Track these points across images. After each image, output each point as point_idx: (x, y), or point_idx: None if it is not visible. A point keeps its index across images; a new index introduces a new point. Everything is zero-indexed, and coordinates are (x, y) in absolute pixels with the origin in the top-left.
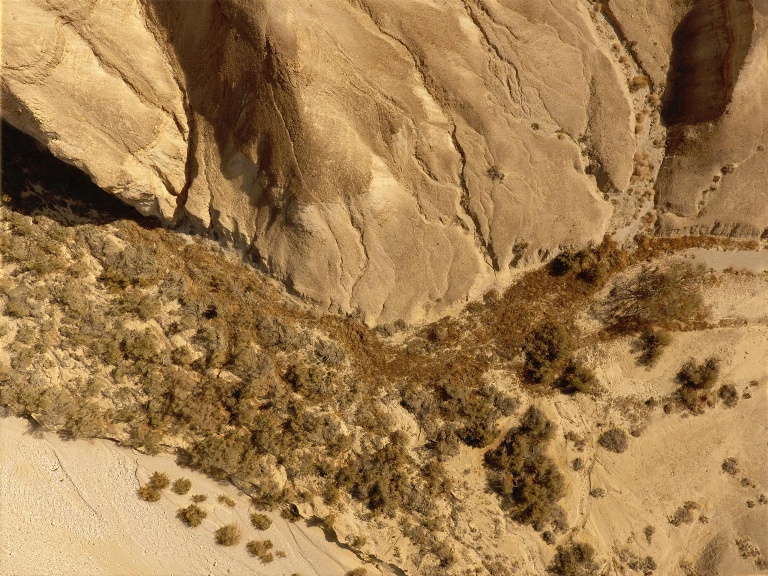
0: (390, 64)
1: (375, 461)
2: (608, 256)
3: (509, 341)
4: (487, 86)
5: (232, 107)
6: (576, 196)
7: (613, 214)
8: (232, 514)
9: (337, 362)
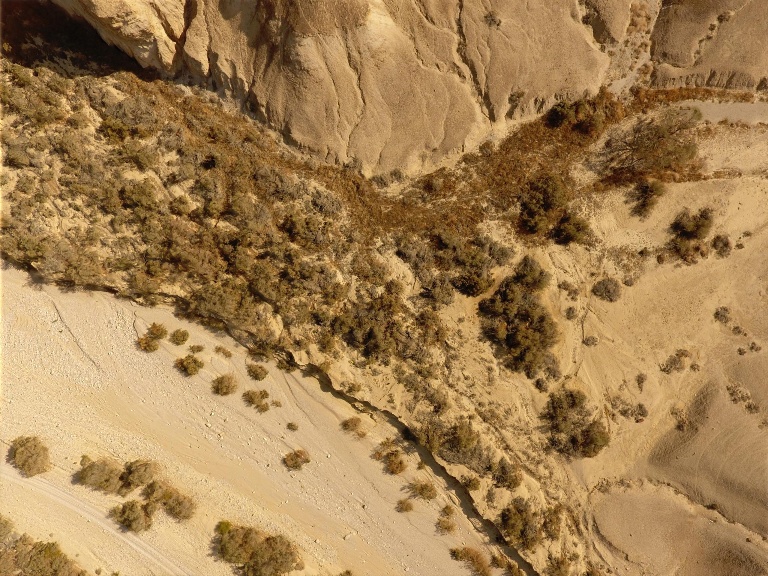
0: None
1: (370, 308)
2: (604, 107)
3: (504, 192)
4: None
5: None
6: (572, 44)
7: (609, 66)
8: (229, 365)
9: (333, 211)
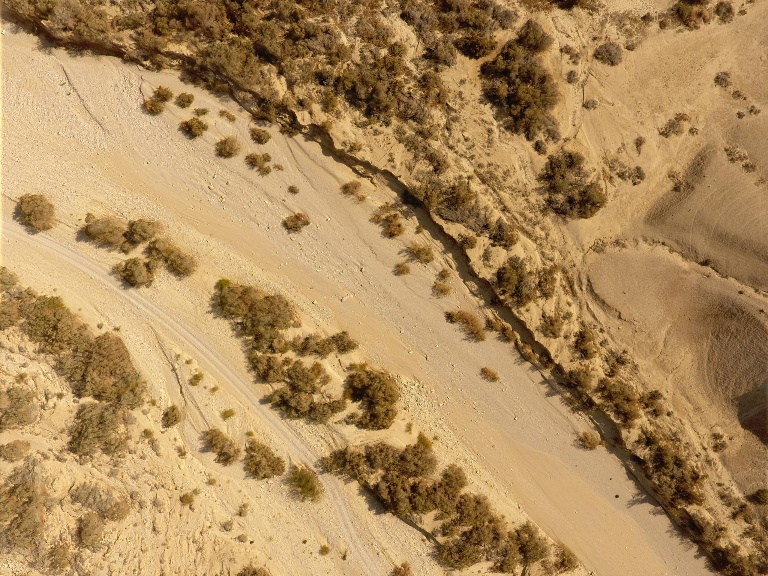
0: None
1: (373, 68)
2: None
3: None
4: None
5: None
6: None
7: None
8: (232, 128)
9: None
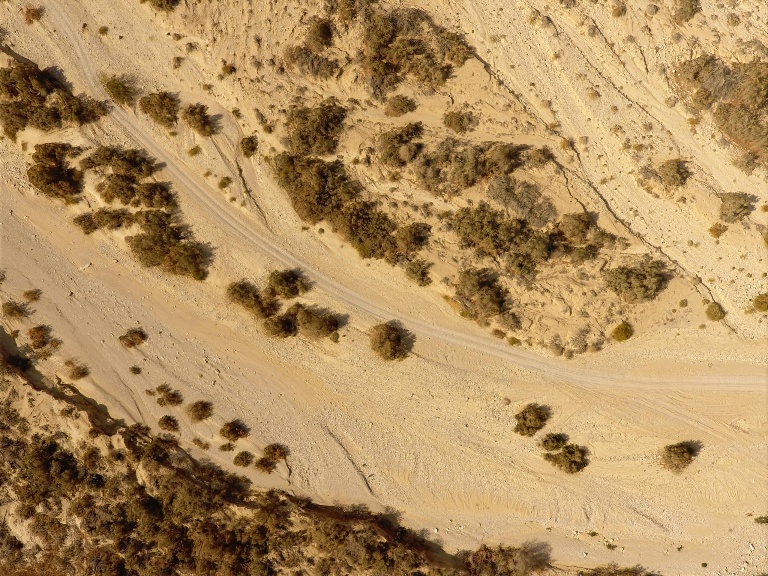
0: None
1: (46, 492)
2: None
3: None
4: None
5: None
6: None
7: None
8: (196, 431)
9: None
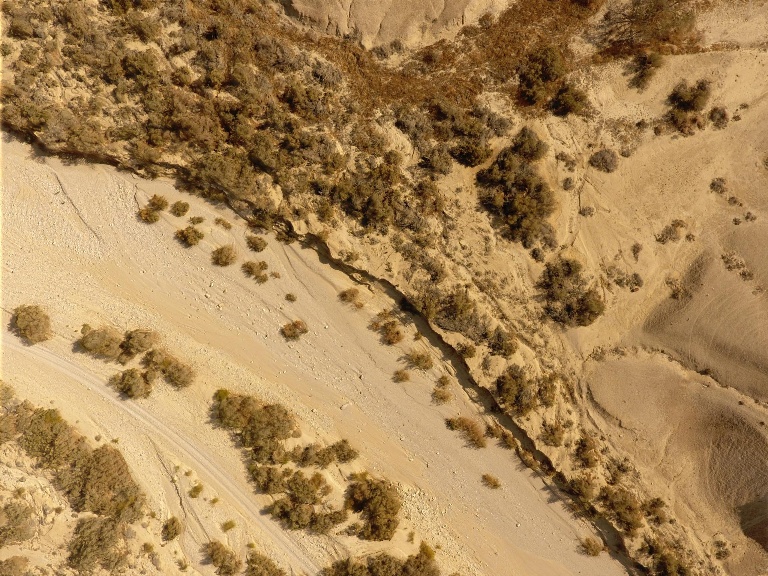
0: None
1: (369, 178)
2: None
3: (503, 63)
4: None
5: None
6: None
7: None
8: (228, 236)
9: (334, 82)
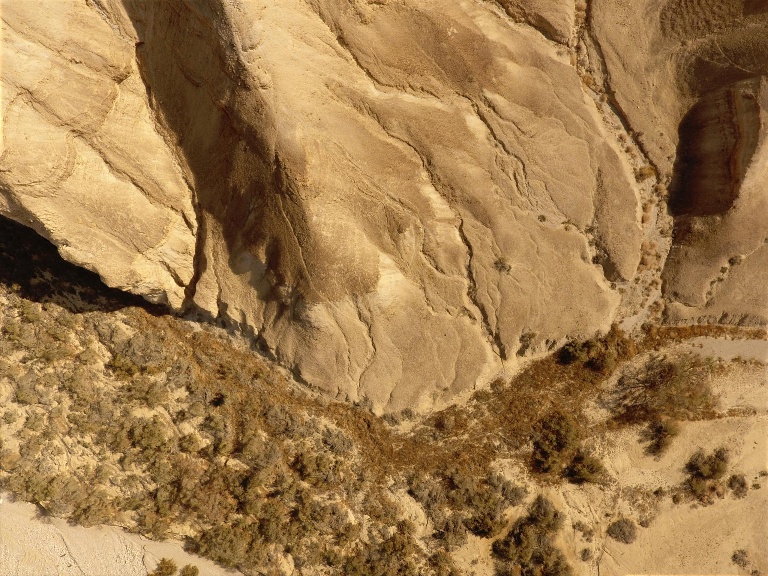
0: (398, 167)
1: (382, 551)
2: (615, 345)
3: (517, 430)
4: (494, 180)
5: (241, 209)
6: (583, 287)
7: (620, 303)
8: None
9: (344, 451)
